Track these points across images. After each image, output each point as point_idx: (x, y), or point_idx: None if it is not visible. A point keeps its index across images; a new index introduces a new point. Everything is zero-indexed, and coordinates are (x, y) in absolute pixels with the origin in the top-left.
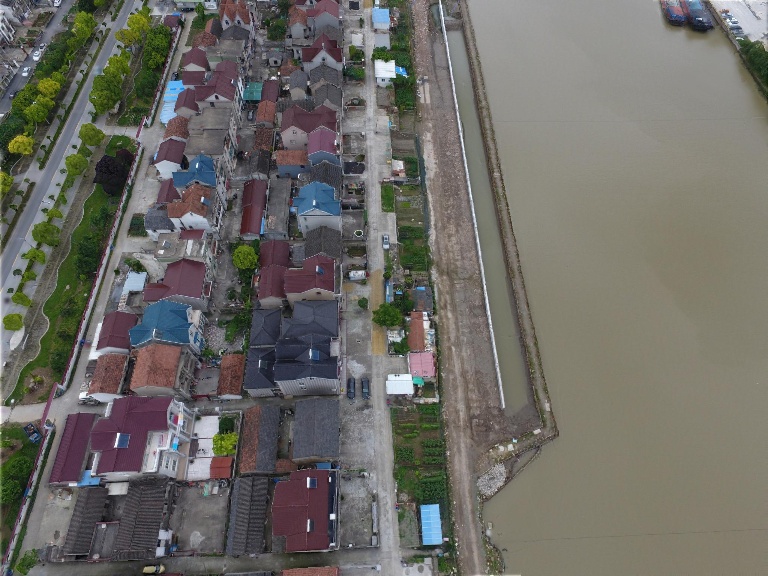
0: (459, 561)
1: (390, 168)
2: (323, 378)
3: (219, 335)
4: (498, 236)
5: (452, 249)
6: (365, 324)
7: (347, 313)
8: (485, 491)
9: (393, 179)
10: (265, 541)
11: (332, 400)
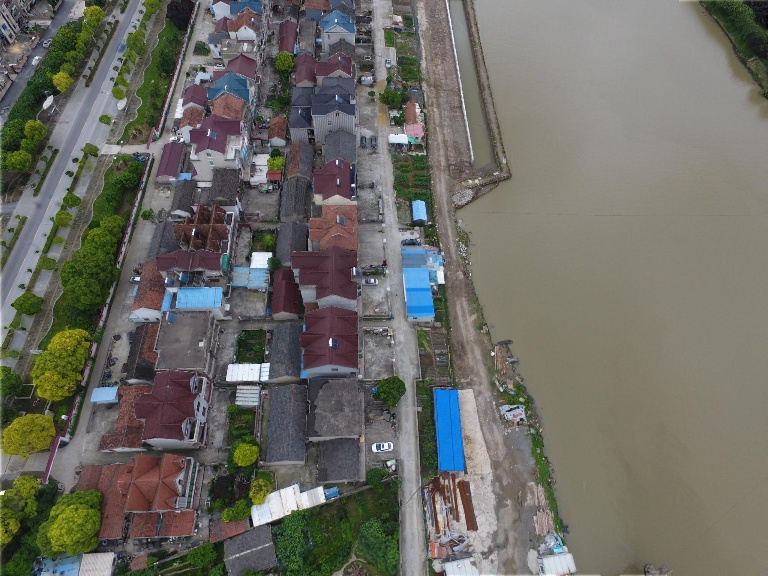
0: (438, 234)
1: (391, 21)
2: (345, 113)
3: (266, 112)
4: (474, 71)
5: (438, 73)
6: (373, 109)
7: (360, 103)
8: (457, 202)
9: (394, 26)
10: (306, 215)
11: (351, 134)
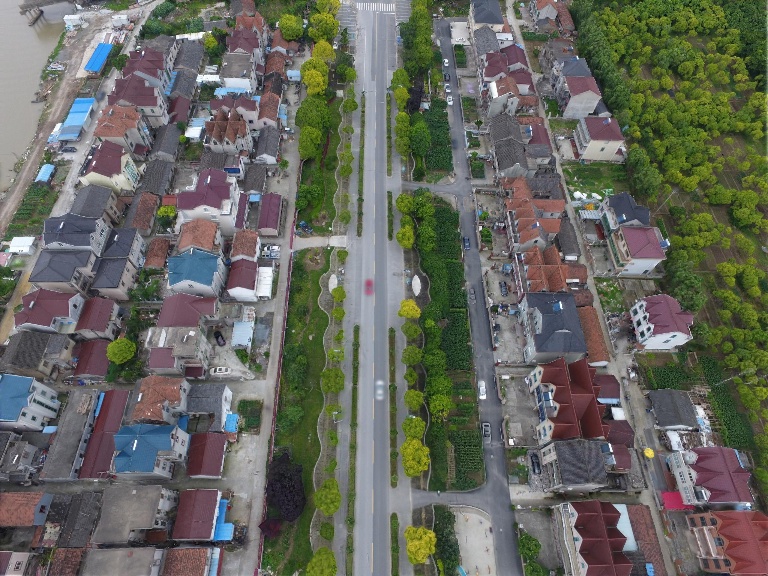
0: None
1: None
2: None
3: None
4: None
5: None
6: None
7: None
8: (2, 193)
9: None
10: None
11: None
